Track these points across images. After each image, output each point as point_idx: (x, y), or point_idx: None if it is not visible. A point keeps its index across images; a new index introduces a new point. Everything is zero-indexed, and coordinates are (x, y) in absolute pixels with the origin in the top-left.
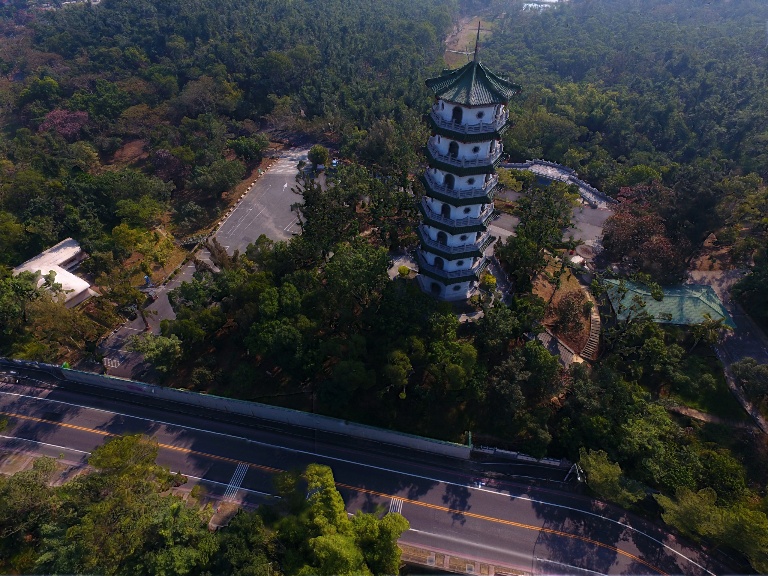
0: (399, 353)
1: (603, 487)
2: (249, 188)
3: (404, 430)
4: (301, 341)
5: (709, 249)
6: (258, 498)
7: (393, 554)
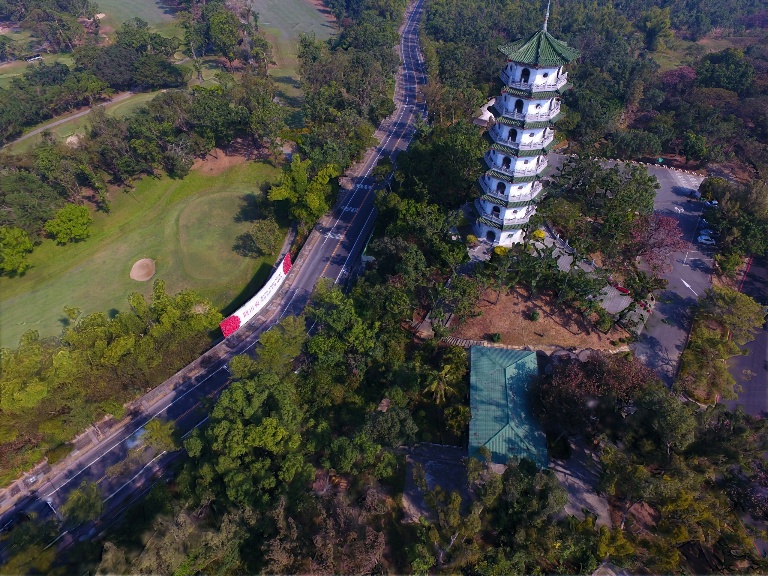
0: (388, 166)
1: (316, 293)
2: (633, 162)
3: (379, 231)
4: (412, 152)
5: (692, 575)
6: (352, 193)
7: (302, 208)
